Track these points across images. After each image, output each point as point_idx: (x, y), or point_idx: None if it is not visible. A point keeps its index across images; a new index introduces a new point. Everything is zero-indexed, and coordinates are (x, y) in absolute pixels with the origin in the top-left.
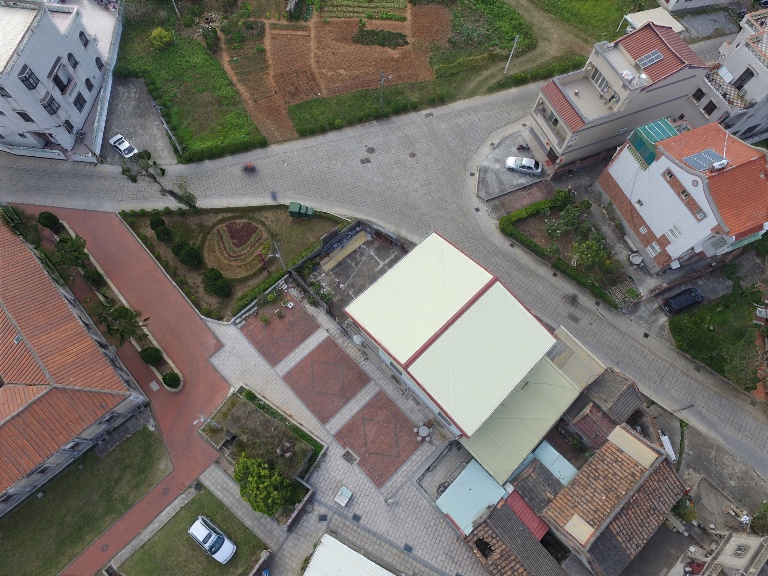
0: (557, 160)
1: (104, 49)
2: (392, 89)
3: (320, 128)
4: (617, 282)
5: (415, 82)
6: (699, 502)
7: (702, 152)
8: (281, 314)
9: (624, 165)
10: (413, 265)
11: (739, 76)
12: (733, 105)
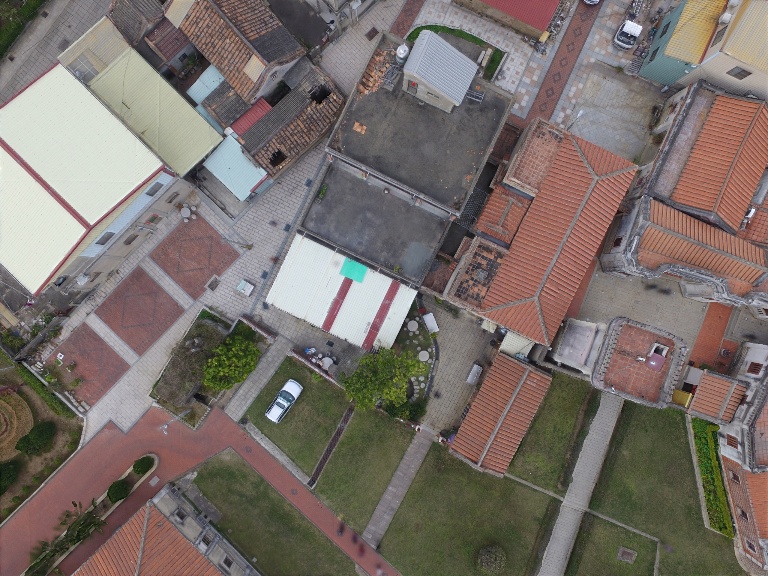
0: None
1: None
2: None
3: None
4: None
5: None
6: None
7: None
8: (71, 365)
9: None
10: None
11: None
12: None
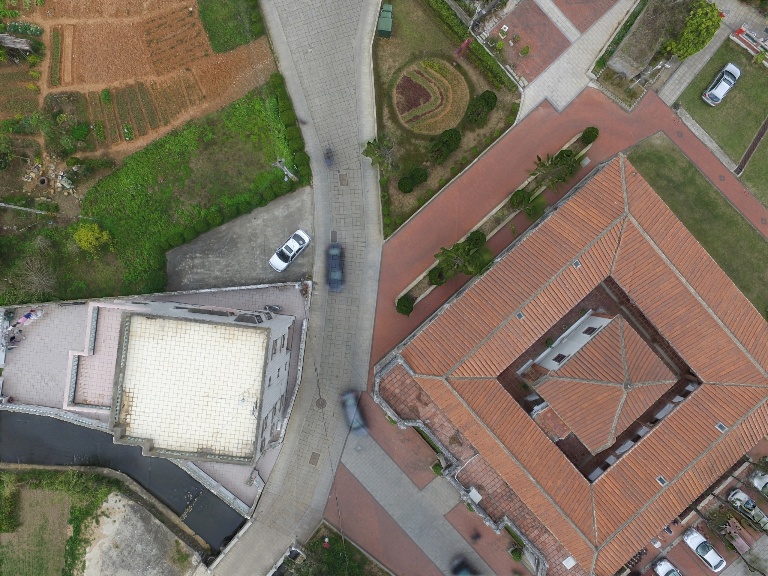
0: None
1: None
2: None
3: (255, 3)
4: None
5: None
6: None
7: None
8: None
9: None
10: None
11: None
12: None
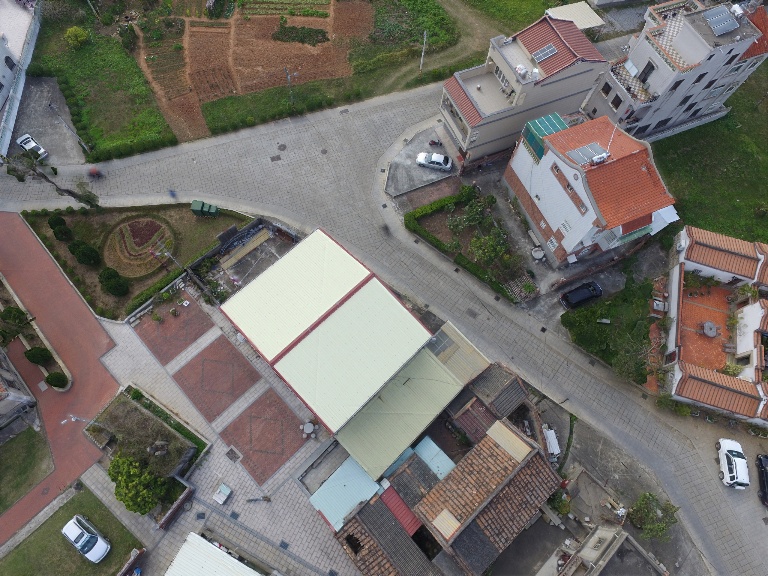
0: (467, 155)
1: (20, 48)
2: (309, 86)
3: (231, 126)
4: (515, 277)
5: (332, 79)
6: (577, 495)
7: (587, 146)
8: (176, 313)
9: (522, 160)
10: (293, 262)
11: (643, 69)
12: (637, 98)
